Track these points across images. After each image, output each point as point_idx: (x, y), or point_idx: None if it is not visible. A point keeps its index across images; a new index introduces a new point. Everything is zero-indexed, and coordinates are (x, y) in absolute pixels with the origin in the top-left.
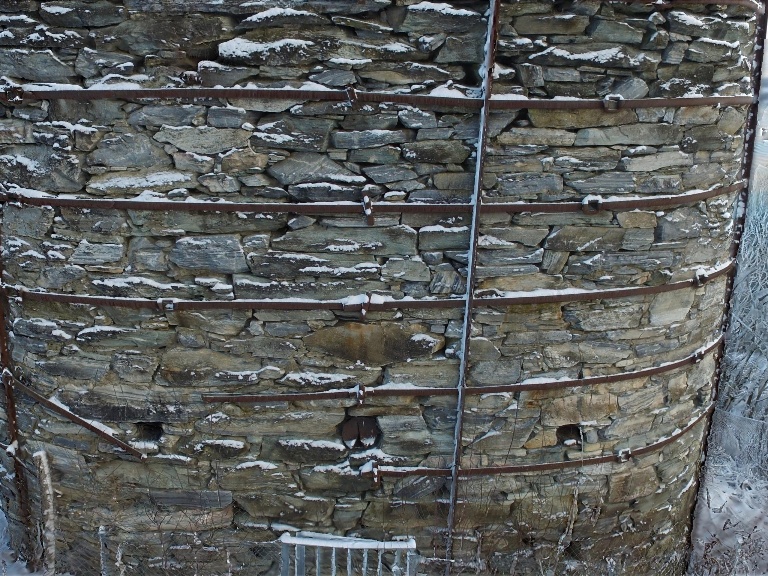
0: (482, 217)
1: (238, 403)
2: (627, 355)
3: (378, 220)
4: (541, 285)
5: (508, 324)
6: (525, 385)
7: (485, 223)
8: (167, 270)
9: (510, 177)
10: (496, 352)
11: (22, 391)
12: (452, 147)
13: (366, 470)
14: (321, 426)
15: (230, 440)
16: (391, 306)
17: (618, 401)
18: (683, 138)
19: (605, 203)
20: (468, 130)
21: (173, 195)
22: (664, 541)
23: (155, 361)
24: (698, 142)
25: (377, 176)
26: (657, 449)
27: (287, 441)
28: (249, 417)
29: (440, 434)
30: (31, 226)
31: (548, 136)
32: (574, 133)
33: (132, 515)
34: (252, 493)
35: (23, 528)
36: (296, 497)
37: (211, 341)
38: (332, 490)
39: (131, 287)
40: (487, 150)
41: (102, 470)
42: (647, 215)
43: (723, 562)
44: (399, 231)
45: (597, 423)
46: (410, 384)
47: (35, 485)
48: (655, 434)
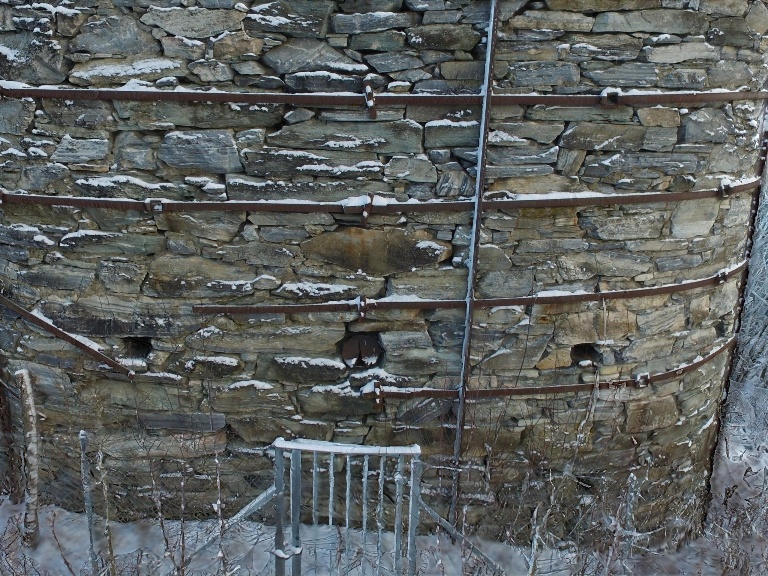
0: (493, 110)
1: (231, 316)
2: (647, 268)
3: (381, 113)
4: (555, 188)
5: (520, 230)
6: (538, 298)
7: (496, 117)
8: (156, 169)
9: (523, 66)
10: (507, 261)
11: (3, 305)
12: (461, 32)
13: (367, 390)
14: (320, 342)
15: (223, 357)
16: (395, 209)
17: (637, 320)
18: (709, 29)
19: (625, 96)
20: (478, 13)
21: (161, 84)
22: (683, 480)
23: (143, 269)
24: (725, 34)
25: (380, 64)
26: (677, 376)
27: (283, 358)
28: (243, 331)
29: (446, 352)
30: (11, 121)
31: (564, 20)
32: (592, 18)
33: (120, 440)
34: (246, 416)
35: (7, 460)
36: (293, 420)
37: (202, 248)
38: (331, 413)
39: (117, 186)
40: (498, 35)
41: (88, 390)
42: (670, 112)
43: (744, 511)
44: (403, 126)
45: (614, 343)
46: (415, 296)
47: (18, 409)
48: (675, 359)
